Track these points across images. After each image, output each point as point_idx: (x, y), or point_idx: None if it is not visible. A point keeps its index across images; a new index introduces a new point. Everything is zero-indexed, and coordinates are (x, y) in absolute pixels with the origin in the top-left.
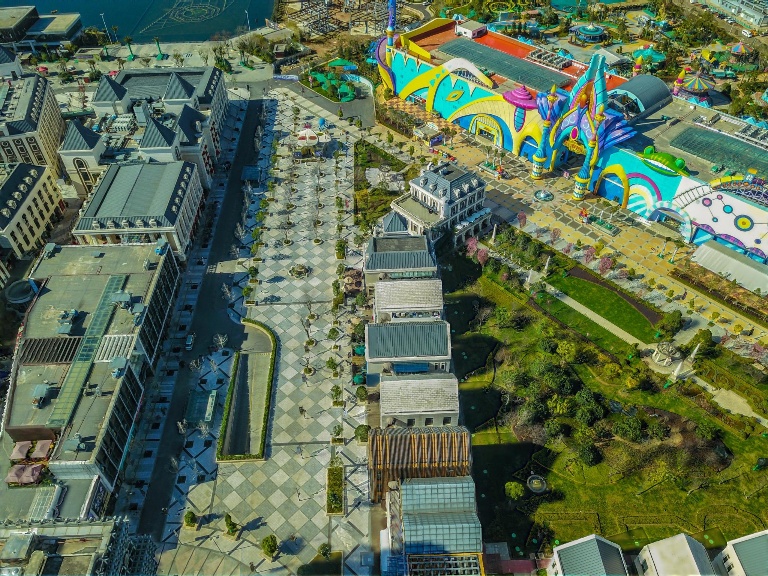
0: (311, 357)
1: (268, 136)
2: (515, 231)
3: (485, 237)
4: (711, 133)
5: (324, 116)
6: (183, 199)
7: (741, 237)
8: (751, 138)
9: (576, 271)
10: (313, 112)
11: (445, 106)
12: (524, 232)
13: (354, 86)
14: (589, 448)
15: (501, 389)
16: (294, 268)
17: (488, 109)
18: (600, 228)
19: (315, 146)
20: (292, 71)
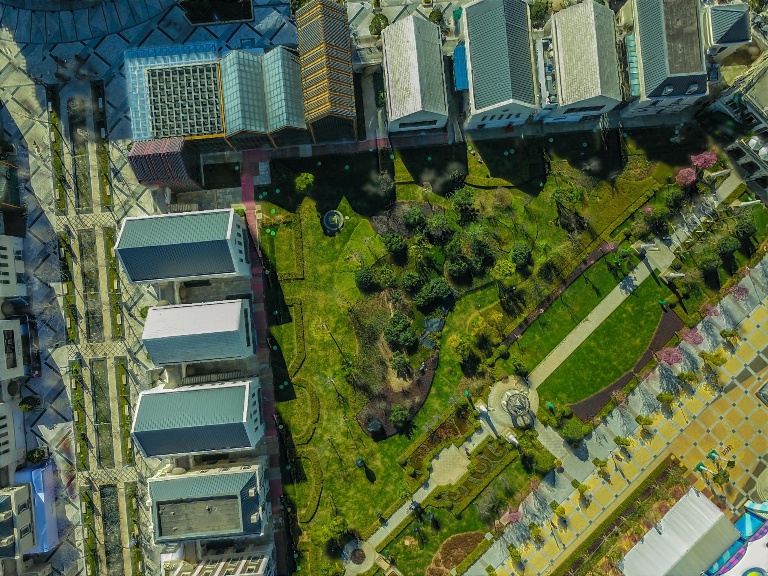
0: None
1: None
2: (766, 244)
3: (751, 196)
4: None
5: None
6: None
7: (734, 573)
8: None
9: (673, 321)
10: None
11: None
12: (763, 257)
13: None
14: (370, 279)
15: None
16: None
17: None
18: None
19: None
20: None
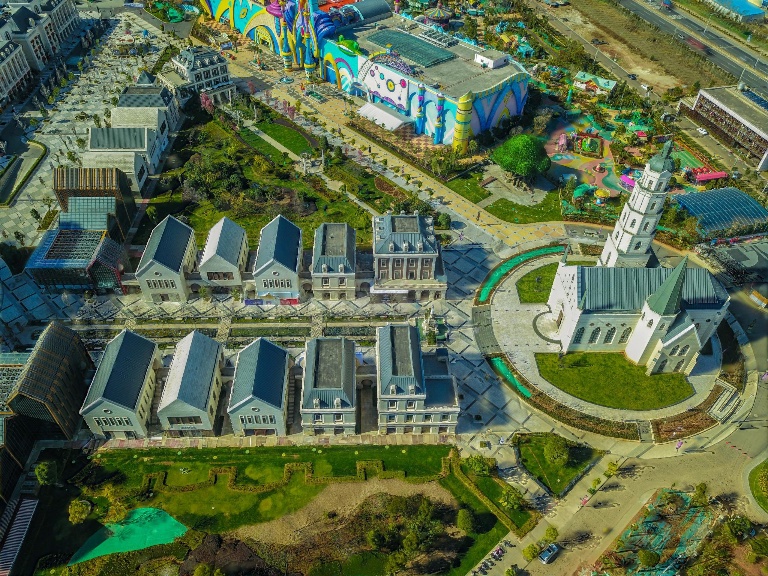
0: (67, 160)
1: (102, 42)
2: (252, 99)
3: None
4: (400, 33)
5: (151, 31)
6: (1, 63)
7: (392, 97)
8: (427, 37)
9: (279, 120)
10: (144, 28)
11: (240, 23)
12: (258, 100)
13: (184, 12)
14: (220, 200)
15: (186, 177)
16: (78, 114)
17: (261, 21)
18: (313, 98)
19: (127, 44)
20: (142, 2)
